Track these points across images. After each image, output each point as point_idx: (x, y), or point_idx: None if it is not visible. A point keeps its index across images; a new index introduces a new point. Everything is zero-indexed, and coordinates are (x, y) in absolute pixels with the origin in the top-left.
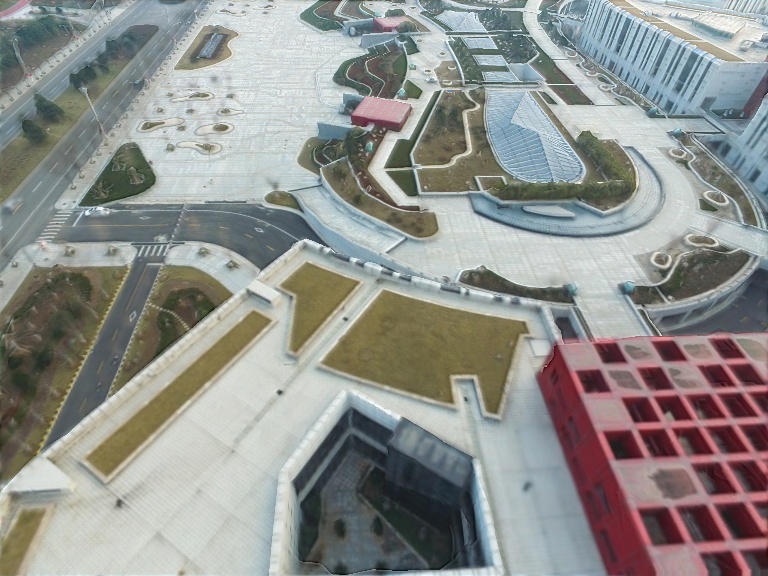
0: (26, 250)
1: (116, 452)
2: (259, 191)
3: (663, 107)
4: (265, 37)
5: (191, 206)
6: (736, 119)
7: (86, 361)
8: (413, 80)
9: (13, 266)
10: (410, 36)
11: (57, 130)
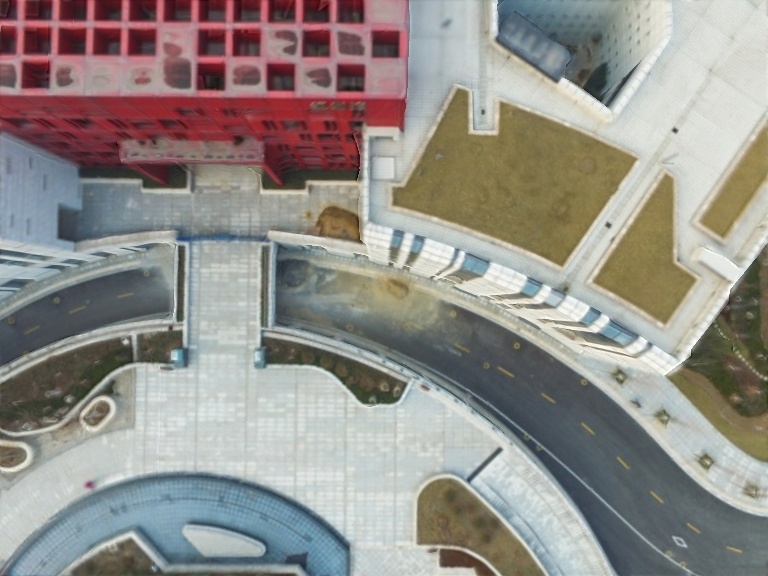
0: None
1: None
2: None
3: None
4: None
5: None
6: None
7: None
8: None
9: None
10: None
11: None
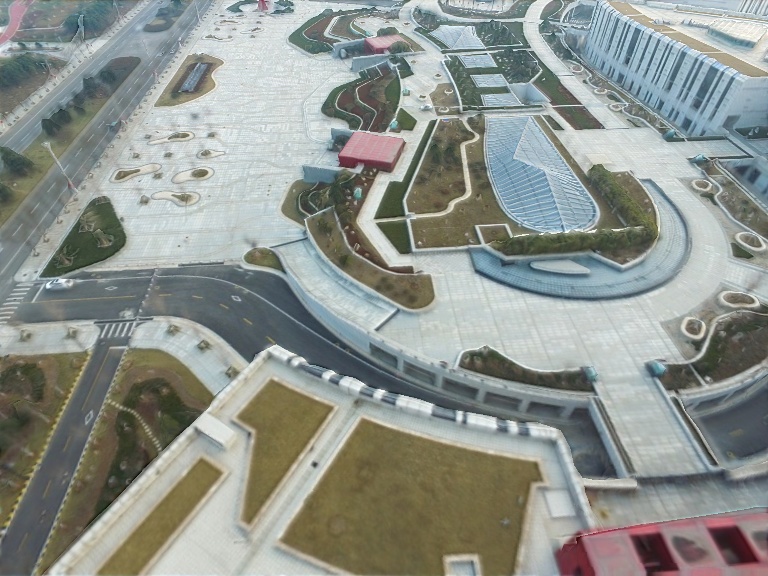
0: None
1: None
2: (238, 249)
3: (680, 125)
4: (251, 64)
5: (163, 271)
6: (763, 139)
7: (31, 481)
8: (407, 108)
9: None
10: (403, 57)
11: (25, 185)
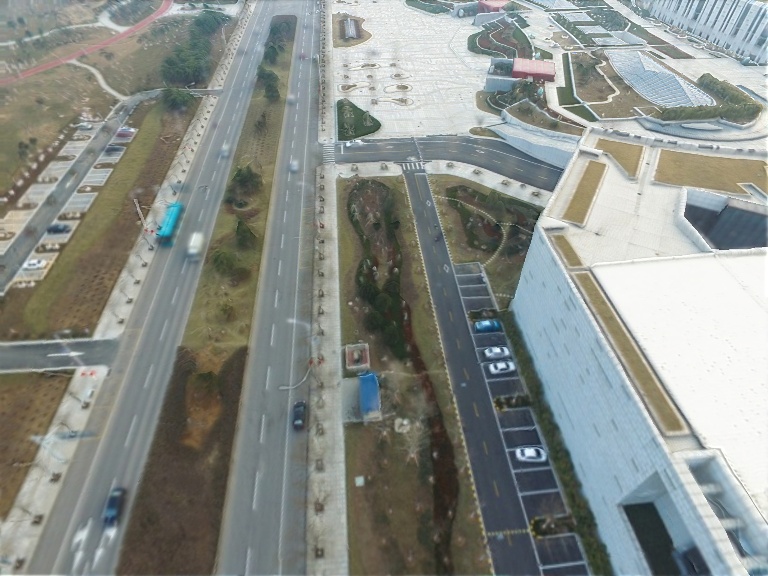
0: (323, 168)
1: (577, 215)
2: (462, 128)
3: None
4: (388, 21)
5: (418, 139)
6: None
7: (417, 228)
8: (539, 46)
9: (321, 178)
10: None
11: None
